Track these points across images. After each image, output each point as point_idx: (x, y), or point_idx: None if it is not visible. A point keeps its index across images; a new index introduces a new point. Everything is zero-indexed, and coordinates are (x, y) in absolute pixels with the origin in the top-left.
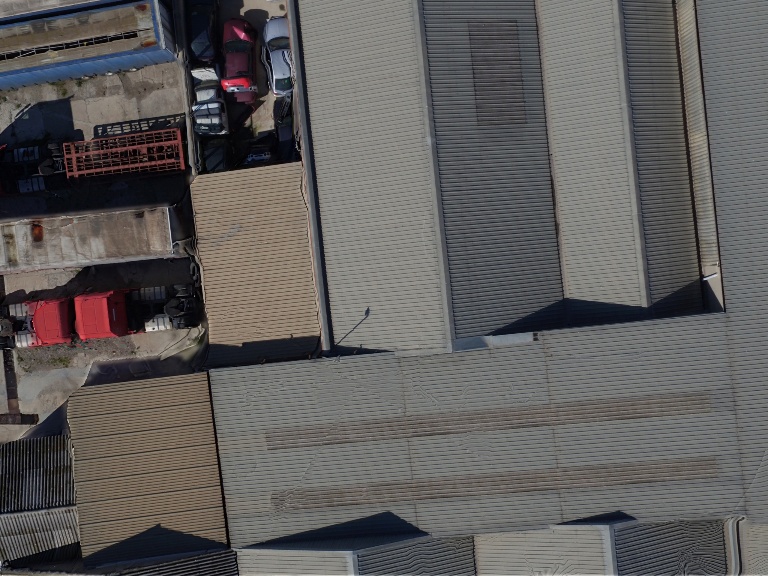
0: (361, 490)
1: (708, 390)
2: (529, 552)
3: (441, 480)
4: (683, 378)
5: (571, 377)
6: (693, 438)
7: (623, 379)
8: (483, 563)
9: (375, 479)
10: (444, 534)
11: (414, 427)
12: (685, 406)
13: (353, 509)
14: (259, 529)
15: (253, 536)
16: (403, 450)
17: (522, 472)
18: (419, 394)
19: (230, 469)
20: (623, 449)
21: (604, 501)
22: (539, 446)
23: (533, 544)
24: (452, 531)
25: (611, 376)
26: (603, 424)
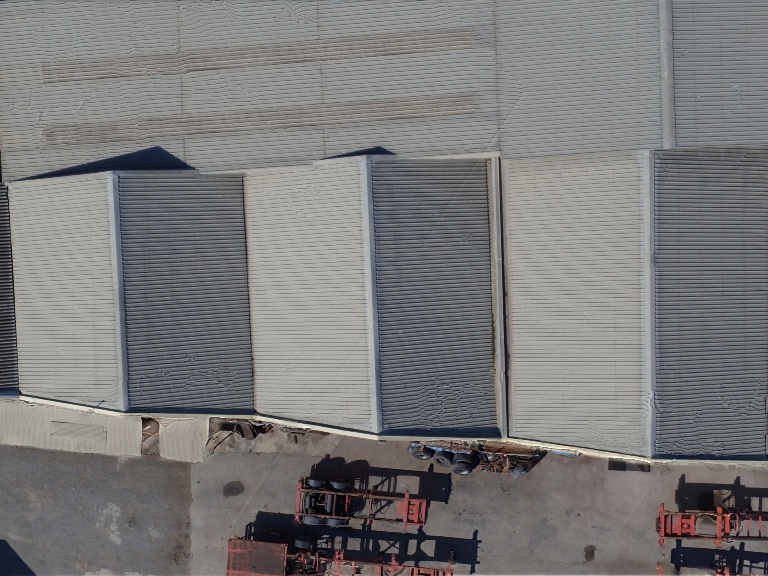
0: (133, 127)
1: (469, 26)
2: (293, 190)
3: (210, 115)
4: (446, 13)
5: (340, 13)
6: (453, 74)
7: (390, 15)
8: (251, 207)
9: (146, 113)
10: (211, 169)
11: (187, 62)
12: (447, 42)
13: (124, 144)
14: (31, 163)
15: (24, 170)
16: (176, 87)
17: (289, 108)
18: (191, 24)
19: (5, 102)
20: (386, 85)
21: (366, 137)
22: (306, 81)
23: (297, 182)
24: (218, 166)
25: (378, 12)
26: (368, 60)
